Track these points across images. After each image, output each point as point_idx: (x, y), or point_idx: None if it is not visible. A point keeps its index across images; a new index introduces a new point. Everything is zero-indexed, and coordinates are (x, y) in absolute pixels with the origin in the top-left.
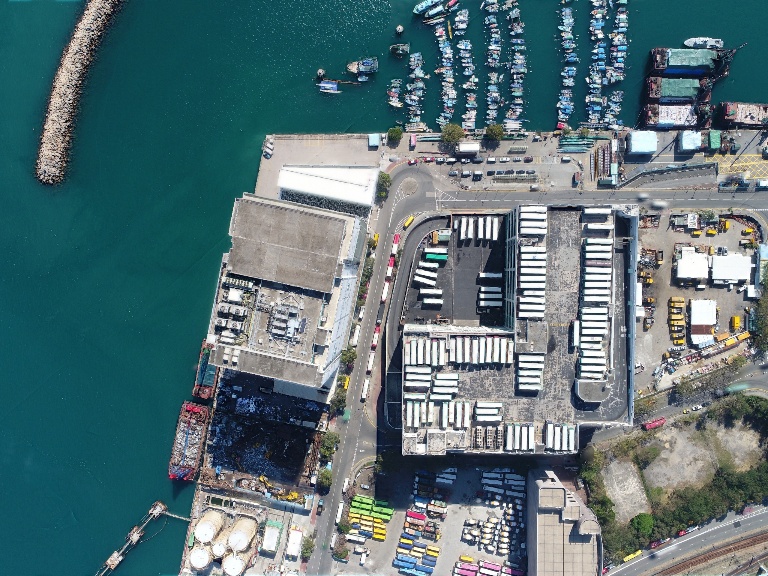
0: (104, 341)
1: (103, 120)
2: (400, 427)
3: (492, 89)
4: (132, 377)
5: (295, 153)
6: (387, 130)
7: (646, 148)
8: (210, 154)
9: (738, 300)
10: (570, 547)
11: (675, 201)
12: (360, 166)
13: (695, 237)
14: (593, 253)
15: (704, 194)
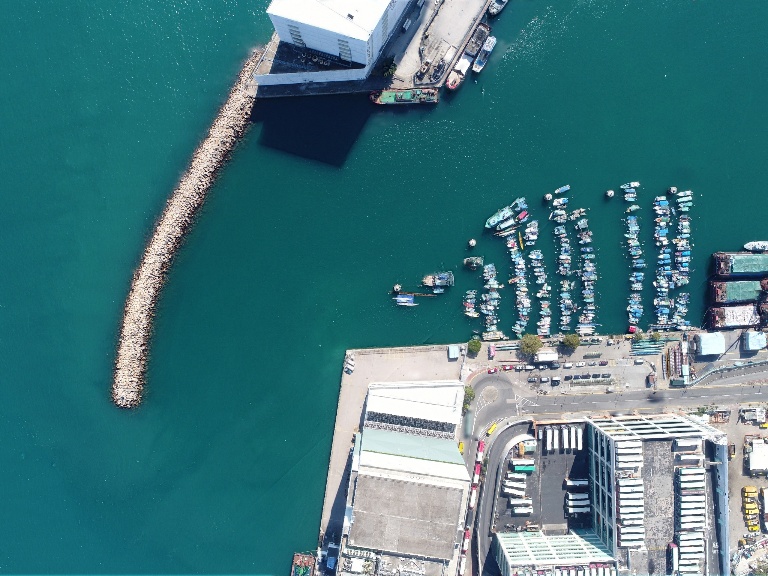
0: (193, 560)
1: (177, 339)
2: None
3: (564, 296)
4: None
5: (376, 367)
6: (464, 339)
7: (715, 351)
8: (290, 371)
9: None
10: None
11: (743, 396)
12: (446, 385)
13: (763, 429)
14: (687, 483)
15: None
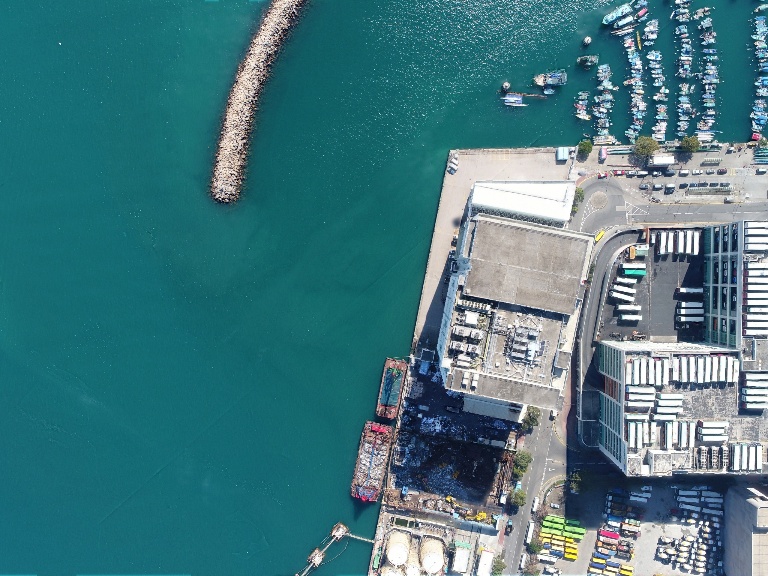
0: (283, 361)
1: None
2: (595, 445)
3: (683, 100)
4: (311, 397)
5: (480, 168)
6: (574, 143)
7: None
8: (391, 170)
9: None
10: None
11: None
12: (555, 181)
13: None
14: None
15: None
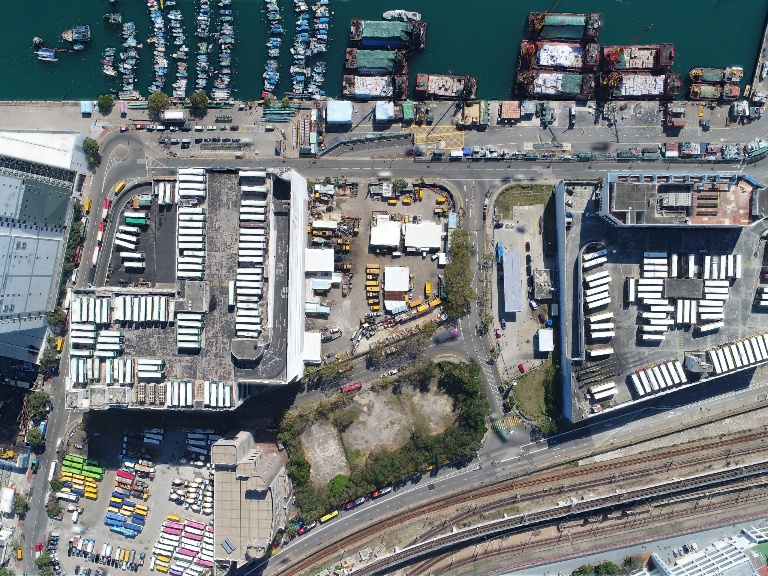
0: None
1: None
2: None
3: (201, 59)
4: None
5: (13, 119)
6: None
7: (341, 117)
8: None
9: (432, 268)
10: (246, 504)
11: (373, 170)
12: (63, 131)
13: (392, 206)
14: (247, 215)
15: (401, 164)
